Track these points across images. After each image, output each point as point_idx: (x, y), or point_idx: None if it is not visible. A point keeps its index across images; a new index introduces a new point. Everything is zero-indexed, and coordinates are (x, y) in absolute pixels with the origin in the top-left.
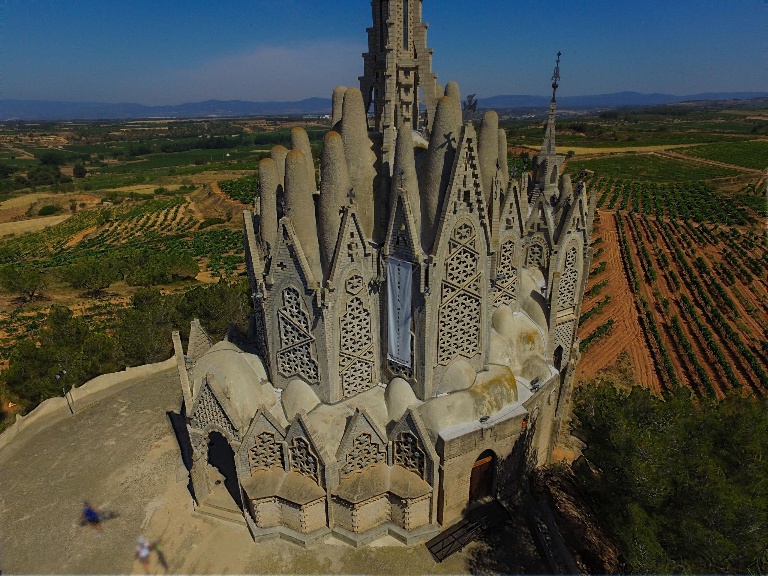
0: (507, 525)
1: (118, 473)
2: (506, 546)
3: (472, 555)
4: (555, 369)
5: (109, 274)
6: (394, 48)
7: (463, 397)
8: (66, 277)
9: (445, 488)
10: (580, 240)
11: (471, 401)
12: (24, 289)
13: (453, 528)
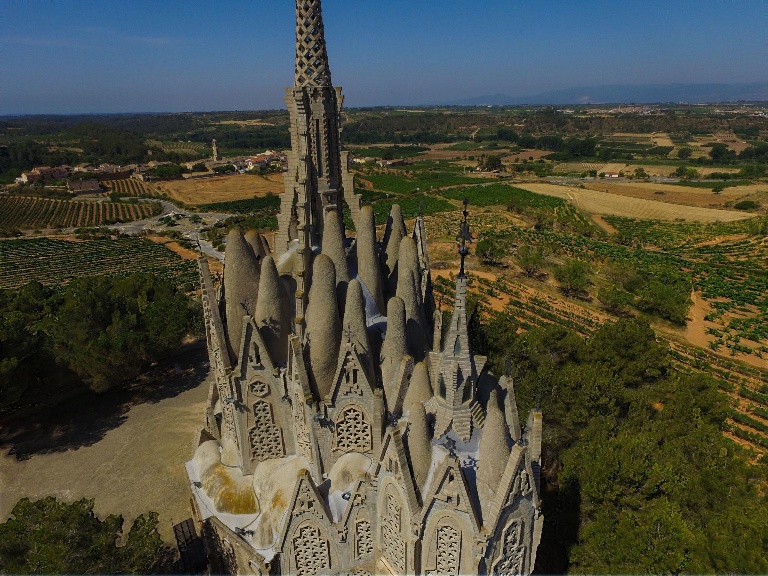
0: (191, 575)
1: None
2: (172, 573)
3: (173, 548)
4: (271, 556)
5: (577, 280)
6: (288, 175)
7: (211, 460)
8: (552, 269)
9: (191, 497)
10: (406, 500)
11: (207, 467)
12: (524, 265)
13: (193, 531)
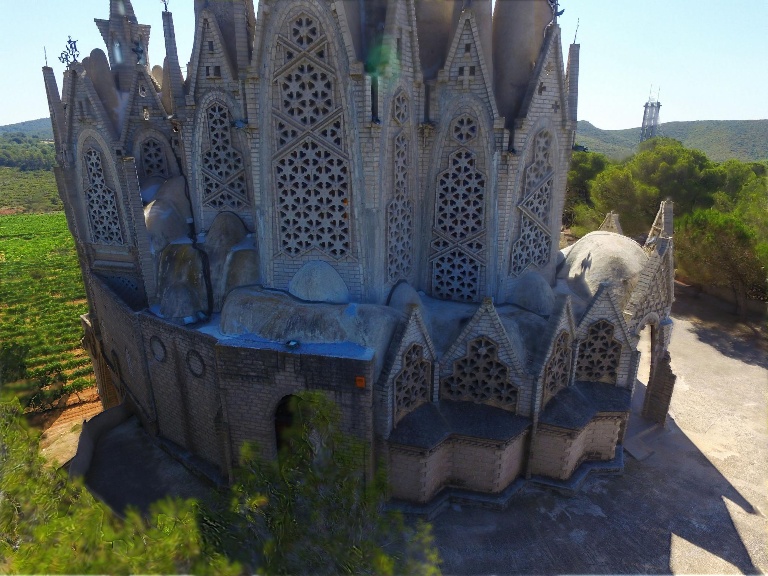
0: None
1: (766, 431)
2: None
3: None
4: None
5: None
6: None
7: None
8: None
9: None
10: None
11: None
12: None
13: None
